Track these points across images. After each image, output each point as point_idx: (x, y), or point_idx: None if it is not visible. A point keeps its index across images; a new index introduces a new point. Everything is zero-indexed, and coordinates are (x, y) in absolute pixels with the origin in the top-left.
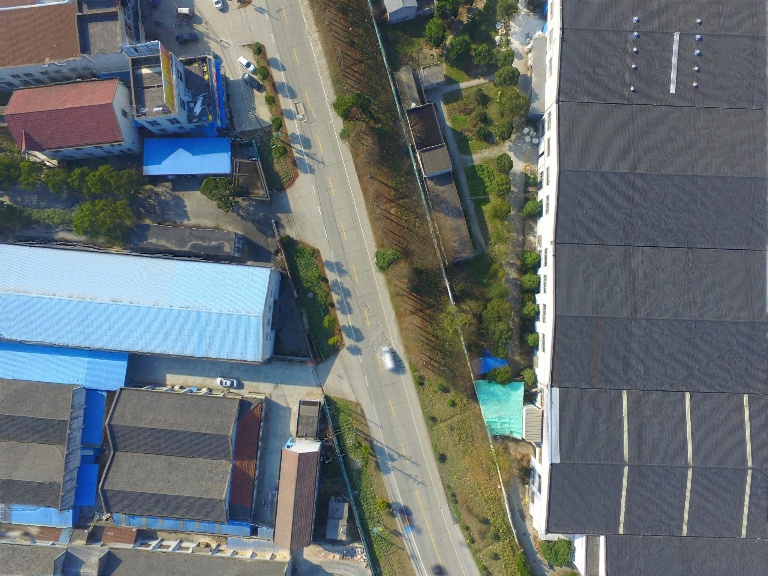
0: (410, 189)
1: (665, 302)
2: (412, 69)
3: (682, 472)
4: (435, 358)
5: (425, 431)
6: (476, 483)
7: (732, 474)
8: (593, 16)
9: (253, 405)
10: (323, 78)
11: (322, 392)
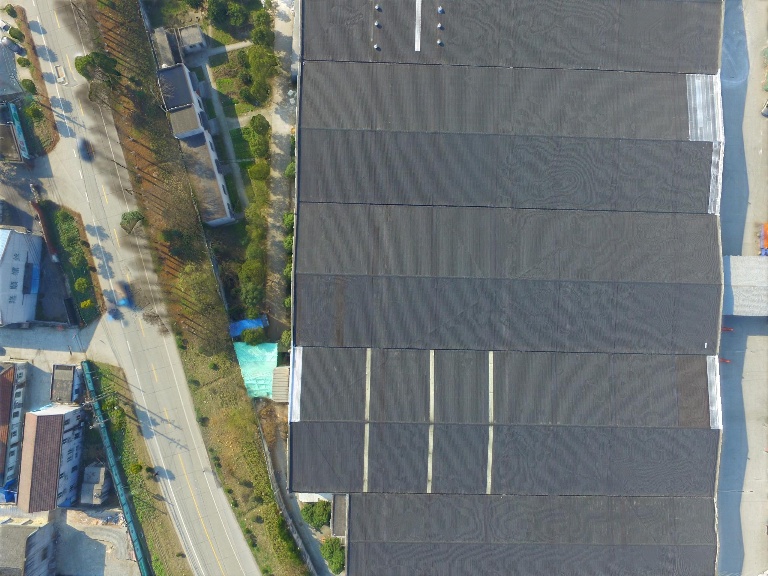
0: (173, 152)
1: (407, 259)
2: (169, 30)
3: (423, 429)
4: (198, 321)
5: (188, 395)
6: (239, 446)
7: (475, 430)
8: None
9: (4, 370)
10: (84, 41)
11: (85, 357)
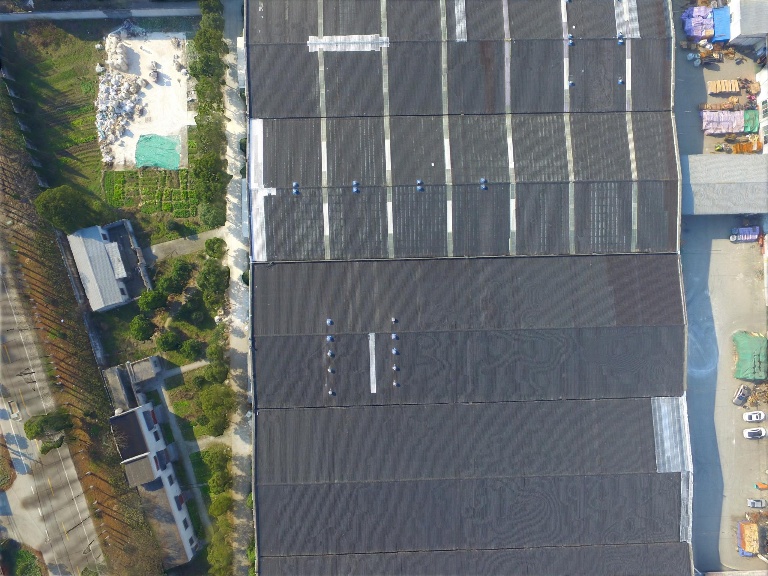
0: None
1: None
2: (121, 366)
3: None
4: None
5: None
6: None
7: None
8: (285, 321)
9: None
10: (36, 374)
11: None
